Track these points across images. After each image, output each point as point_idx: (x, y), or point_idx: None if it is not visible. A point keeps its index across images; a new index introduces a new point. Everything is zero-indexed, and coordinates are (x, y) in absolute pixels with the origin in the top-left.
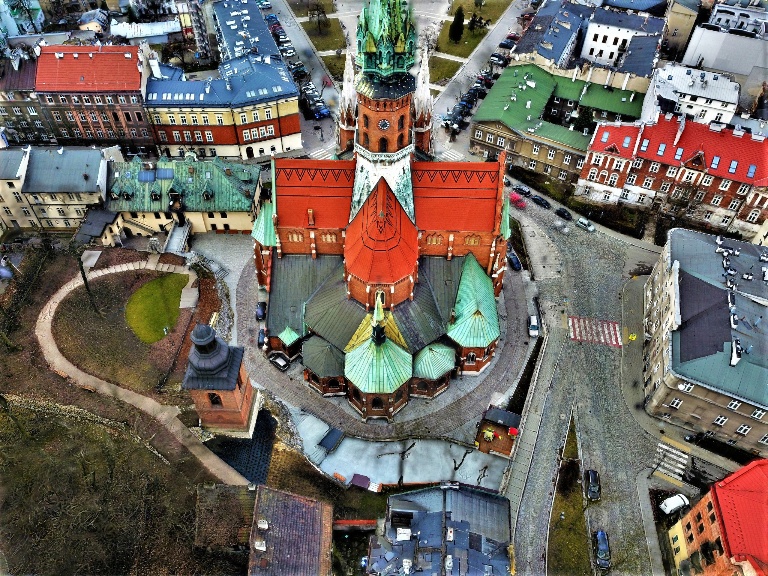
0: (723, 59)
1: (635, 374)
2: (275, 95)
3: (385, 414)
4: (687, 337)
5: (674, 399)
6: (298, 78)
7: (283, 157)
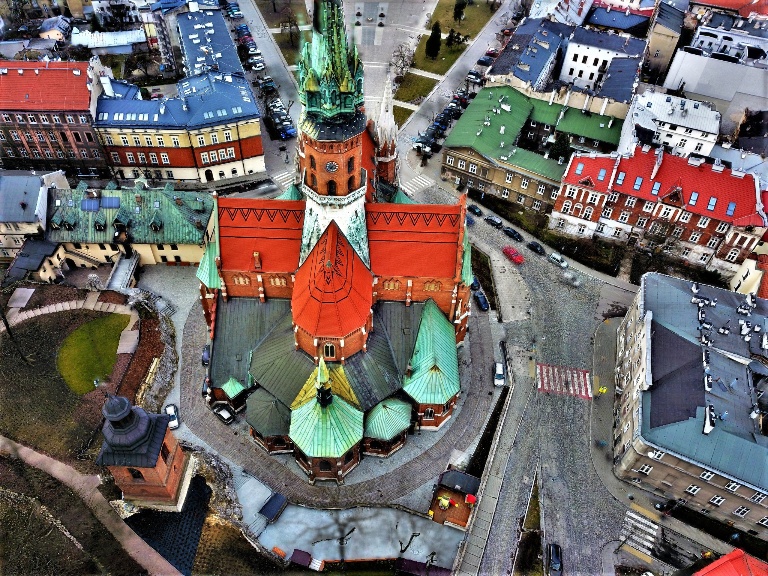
0: (705, 84)
1: (604, 430)
2: (235, 117)
3: (334, 476)
4: (658, 399)
5: (644, 465)
6: (266, 94)
7: (245, 180)
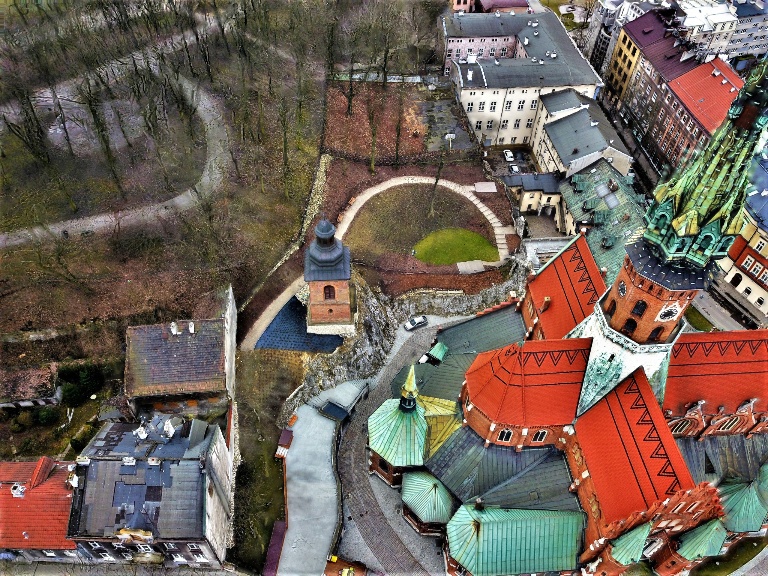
0: None
1: None
2: None
3: None
4: None
5: None
6: None
7: (756, 316)
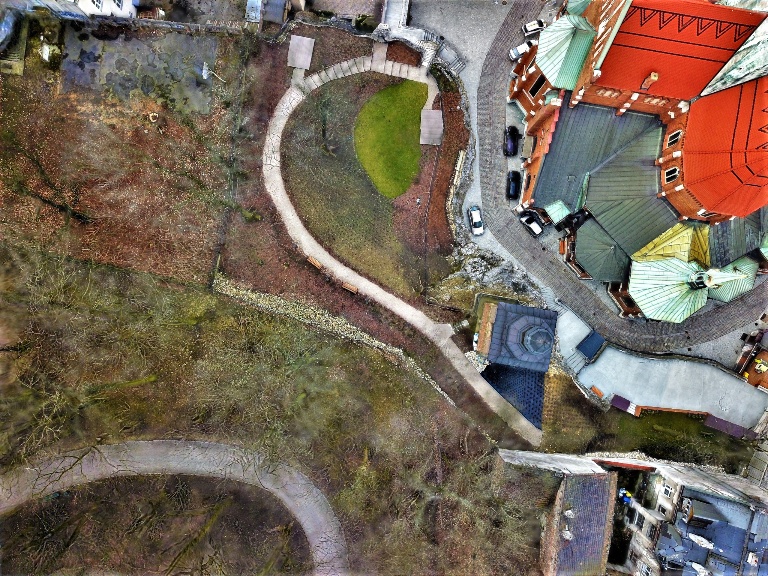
0: None
1: None
2: None
3: None
4: None
5: None
6: None
7: None
